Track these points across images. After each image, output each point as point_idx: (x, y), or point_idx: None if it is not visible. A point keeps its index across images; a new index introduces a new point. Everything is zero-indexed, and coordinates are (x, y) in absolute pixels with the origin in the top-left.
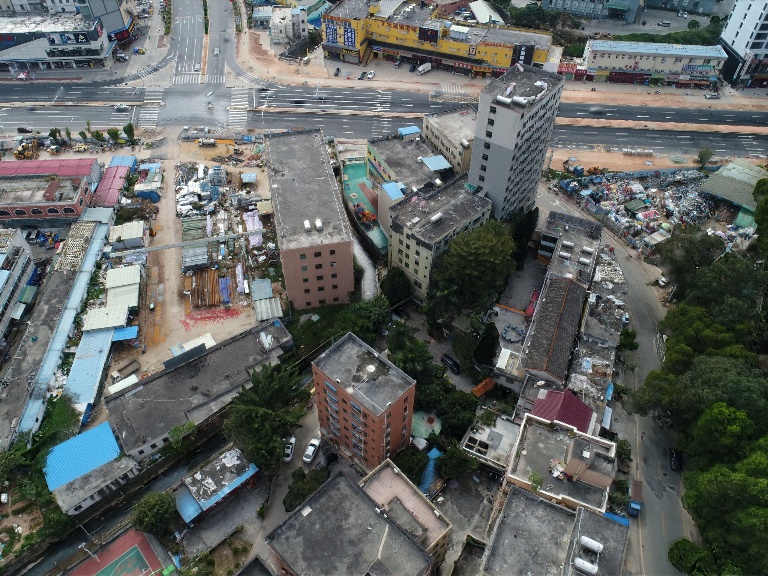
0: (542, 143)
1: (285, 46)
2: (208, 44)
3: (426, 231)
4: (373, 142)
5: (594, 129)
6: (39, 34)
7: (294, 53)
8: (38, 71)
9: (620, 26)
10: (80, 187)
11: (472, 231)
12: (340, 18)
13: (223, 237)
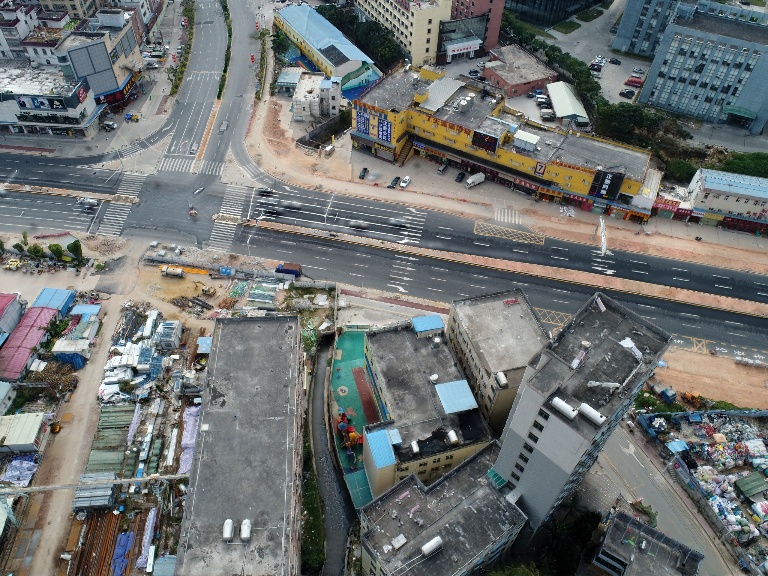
0: (621, 416)
1: (307, 127)
2: (216, 114)
3: (411, 571)
4: (374, 334)
5: (695, 310)
6: (7, 95)
7: (318, 136)
8: (7, 135)
9: (741, 137)
10: None
11: None
12: (375, 107)
13: (128, 481)
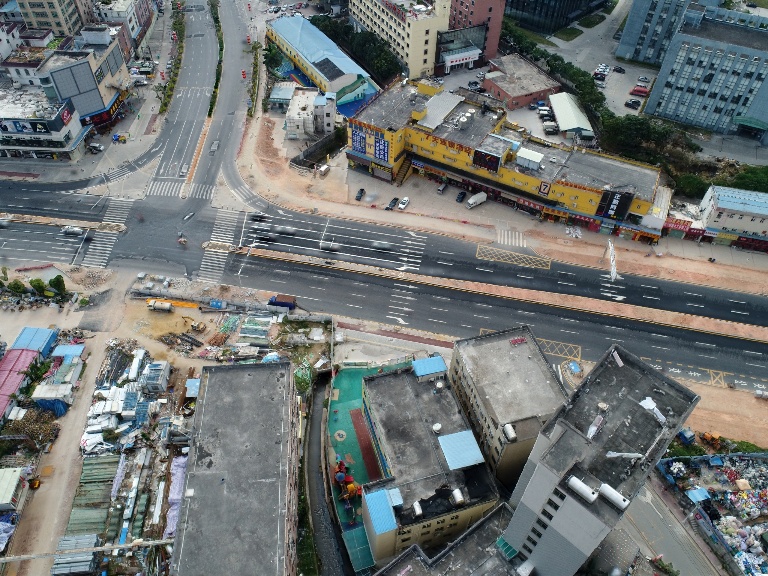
0: None
1: (301, 146)
2: (207, 133)
3: None
4: (372, 379)
5: (711, 339)
6: None
7: (312, 155)
8: None
9: (752, 149)
10: None
11: None
12: (371, 126)
13: (109, 548)
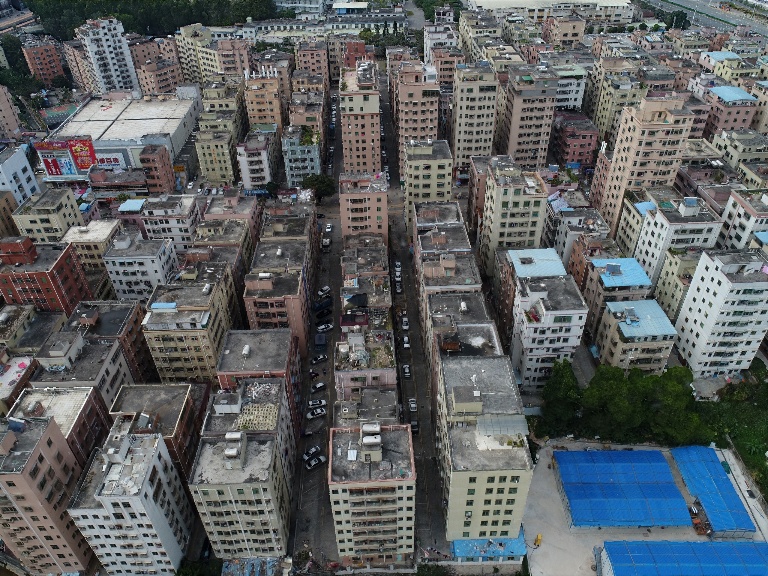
0: None
1: None
2: None
3: None
4: None
5: None
6: None
7: None
8: None
9: None
10: None
11: (2, 39)
12: None
13: None
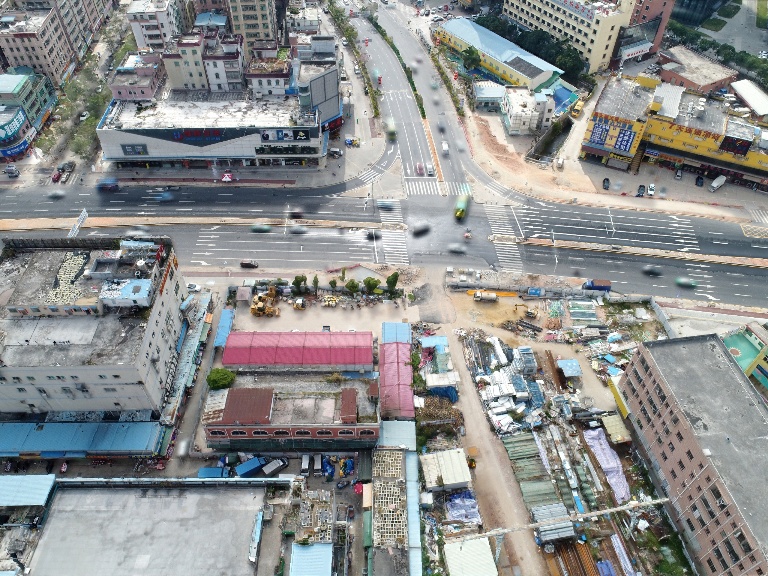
0: None
1: None
2: (431, 134)
3: None
4: None
5: None
6: (252, 129)
7: (537, 149)
8: (241, 169)
9: None
10: (379, 398)
11: None
12: (619, 118)
13: (613, 511)
